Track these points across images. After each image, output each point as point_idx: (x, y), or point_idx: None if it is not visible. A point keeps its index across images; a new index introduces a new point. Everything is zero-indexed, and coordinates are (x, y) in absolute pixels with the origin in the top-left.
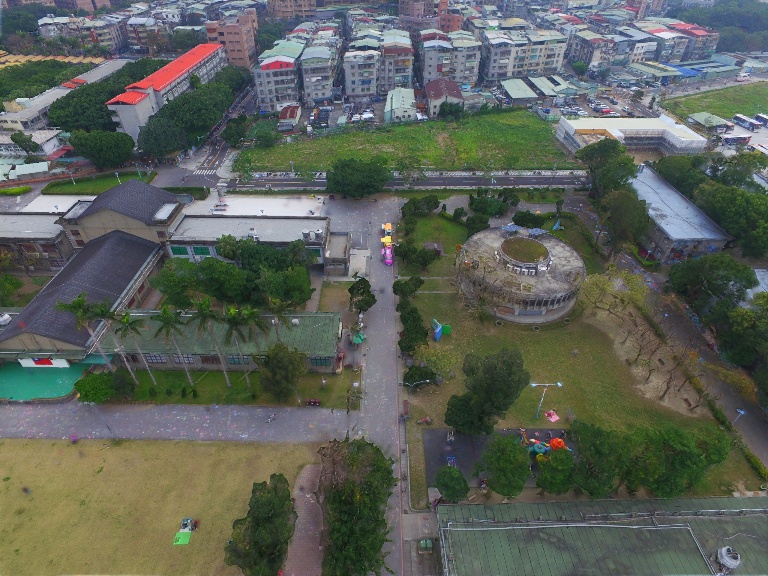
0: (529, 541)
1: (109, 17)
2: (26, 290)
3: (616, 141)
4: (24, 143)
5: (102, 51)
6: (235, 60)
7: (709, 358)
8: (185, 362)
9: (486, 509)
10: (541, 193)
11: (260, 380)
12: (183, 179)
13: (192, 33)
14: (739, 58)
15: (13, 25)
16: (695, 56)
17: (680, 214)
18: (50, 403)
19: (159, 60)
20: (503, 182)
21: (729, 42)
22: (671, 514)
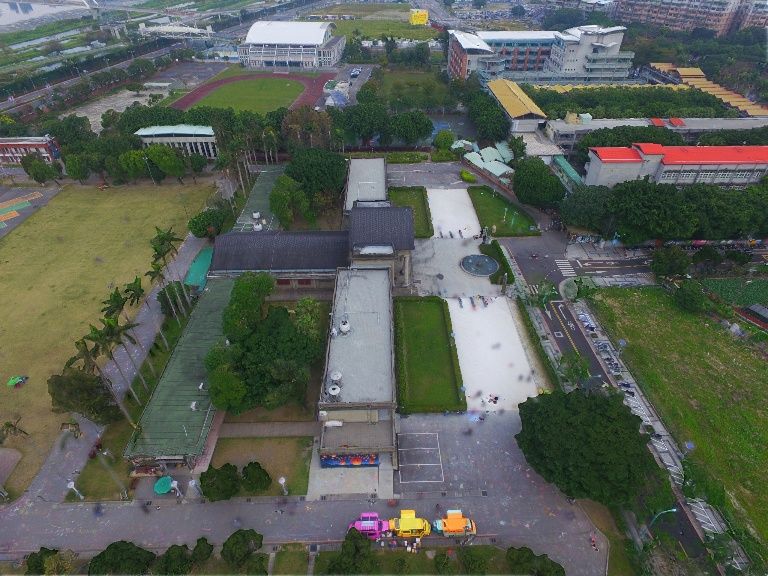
0: None
1: None
2: (322, 229)
3: None
4: (515, 147)
5: None
6: None
7: None
8: None
9: None
10: None
11: None
12: (535, 256)
13: None
14: None
15: None
16: None
17: None
18: None
19: None
20: None
21: None
22: None
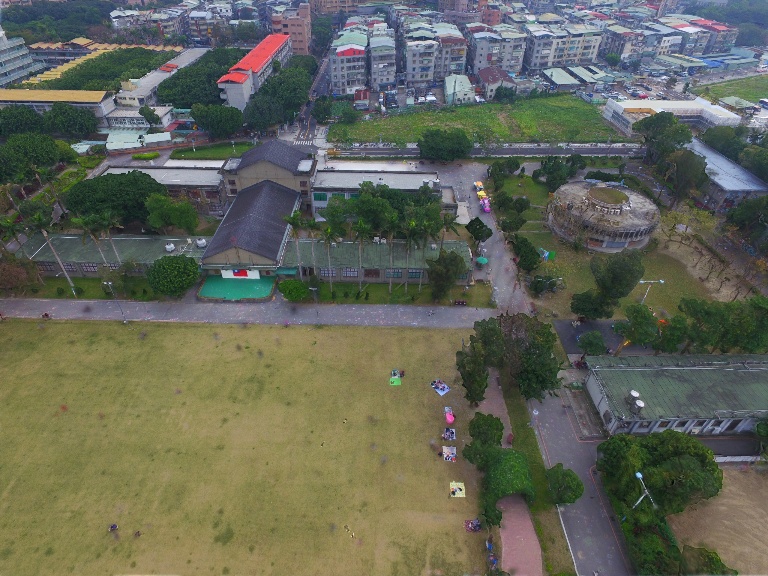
0: (658, 377)
1: (169, 11)
2: None
3: (671, 113)
4: (149, 116)
5: (181, 40)
6: (296, 50)
7: (765, 277)
8: (350, 276)
9: (621, 359)
10: (602, 160)
11: (432, 277)
12: None
13: (253, 25)
14: (757, 51)
15: (78, 18)
16: (716, 49)
17: (729, 172)
18: (255, 302)
19: (235, 48)
20: (566, 152)
21: (746, 37)
22: (757, 363)
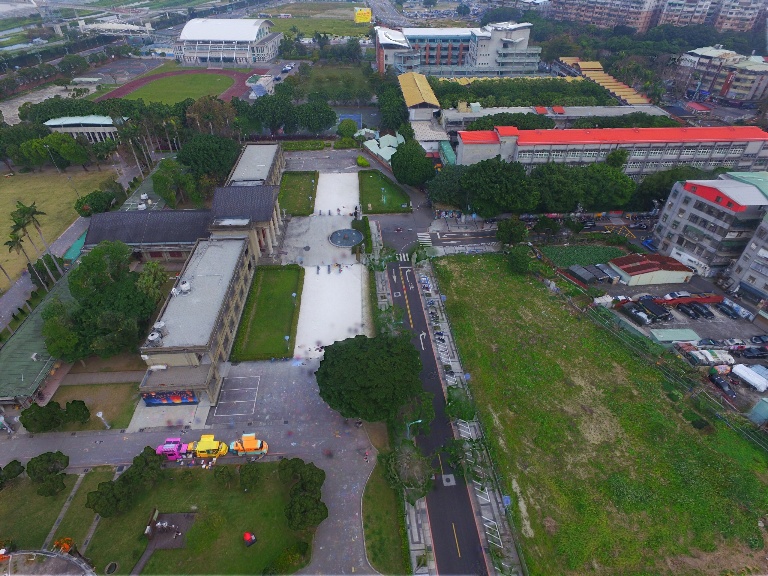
0: None
1: None
2: None
3: None
4: None
5: (654, 93)
6: None
7: None
8: None
9: None
10: None
11: None
12: (399, 229)
13: None
14: None
15: None
16: None
17: None
18: None
19: None
20: None
21: None
22: None
